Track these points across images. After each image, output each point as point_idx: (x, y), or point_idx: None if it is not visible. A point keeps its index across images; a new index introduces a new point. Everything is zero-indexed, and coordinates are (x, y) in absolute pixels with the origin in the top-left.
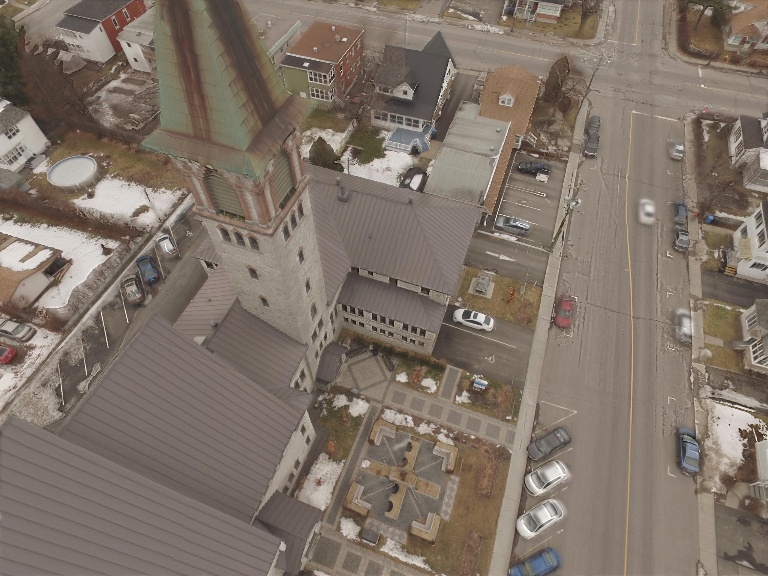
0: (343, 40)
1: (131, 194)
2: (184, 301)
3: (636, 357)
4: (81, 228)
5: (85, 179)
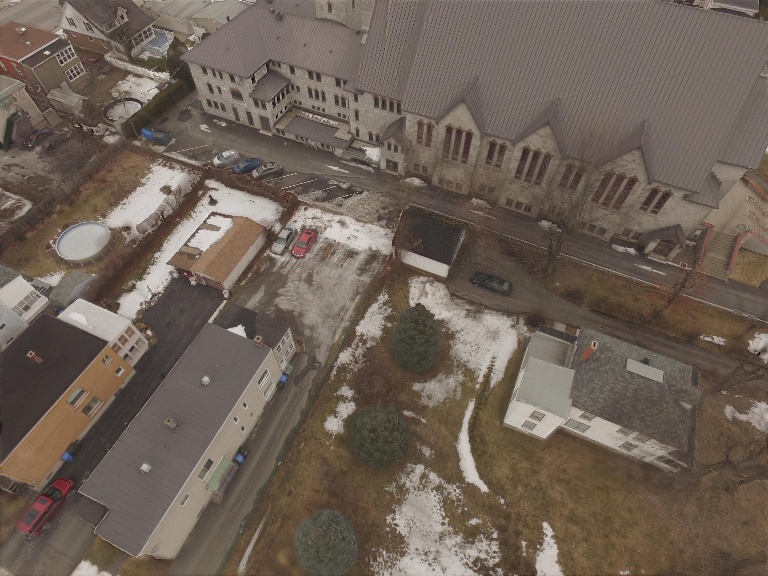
0: (24, 30)
1: (139, 200)
2: (284, 148)
3: (363, 1)
4: (174, 226)
5: (105, 227)
